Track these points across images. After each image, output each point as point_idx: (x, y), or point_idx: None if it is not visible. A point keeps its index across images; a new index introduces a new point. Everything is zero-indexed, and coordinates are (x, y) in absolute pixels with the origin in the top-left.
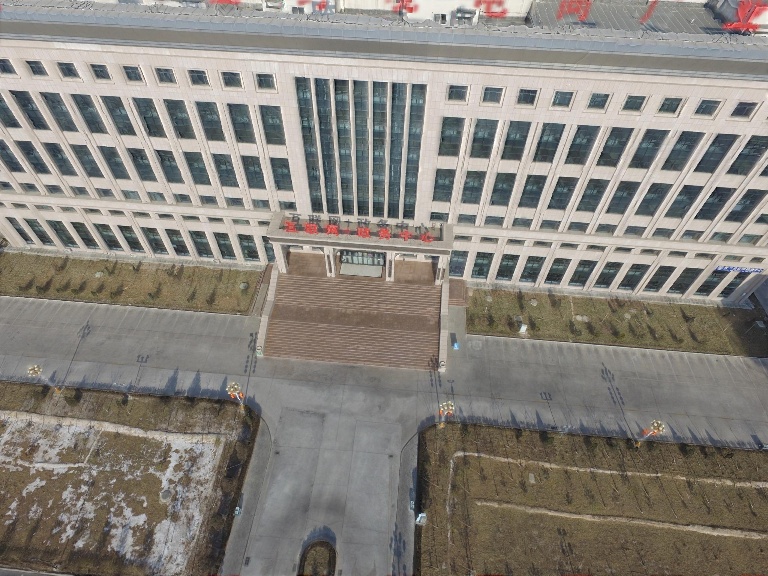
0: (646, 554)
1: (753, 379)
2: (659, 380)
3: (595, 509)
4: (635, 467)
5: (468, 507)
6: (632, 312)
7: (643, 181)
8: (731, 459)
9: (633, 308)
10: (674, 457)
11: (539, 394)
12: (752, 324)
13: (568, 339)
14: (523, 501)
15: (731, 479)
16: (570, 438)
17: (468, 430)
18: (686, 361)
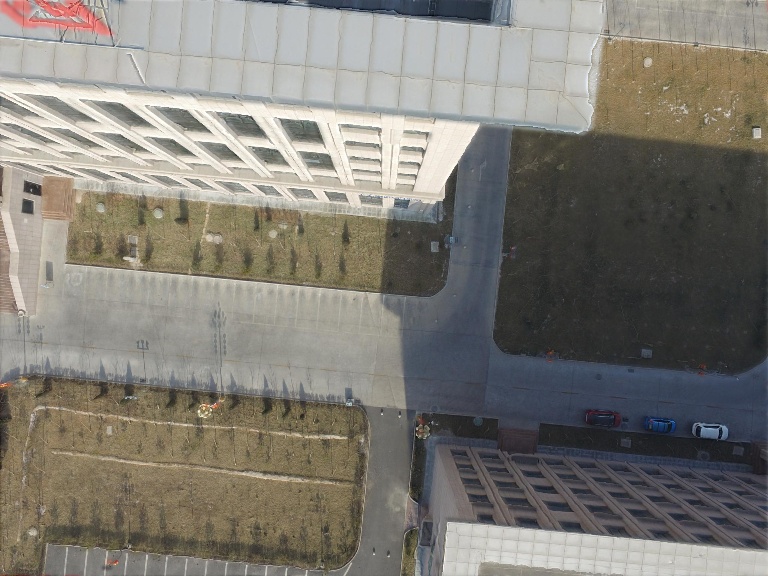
0: (197, 493)
1: (383, 324)
2: (275, 325)
3: (162, 458)
4: (212, 421)
5: (45, 456)
6: (281, 228)
7: (124, 136)
8: (312, 413)
9: (284, 222)
10: (255, 411)
11: (135, 343)
12: (424, 246)
13: (187, 270)
14: (97, 451)
15: (301, 433)
16: (156, 392)
17: (52, 384)
18: (317, 300)
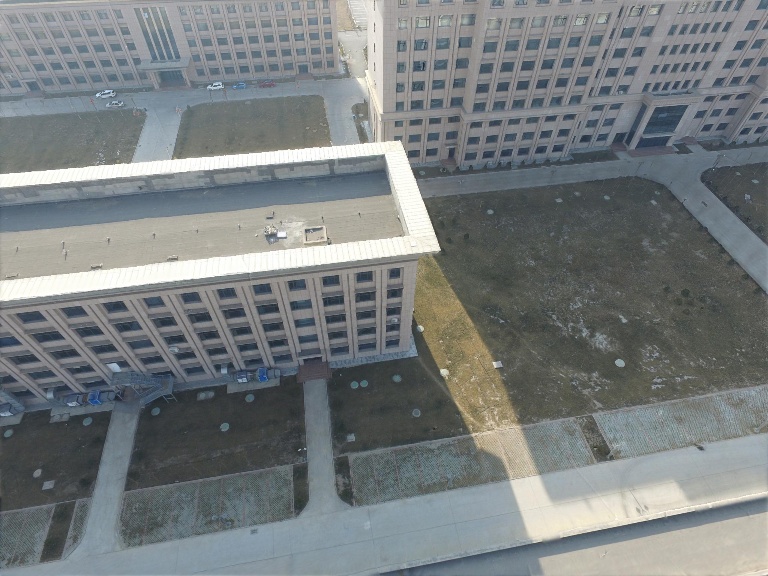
0: None
1: None
2: None
3: None
4: None
5: None
6: None
7: None
8: None
9: None
10: None
11: None
12: (366, 115)
13: None
14: None
15: None
16: None
17: None
18: None
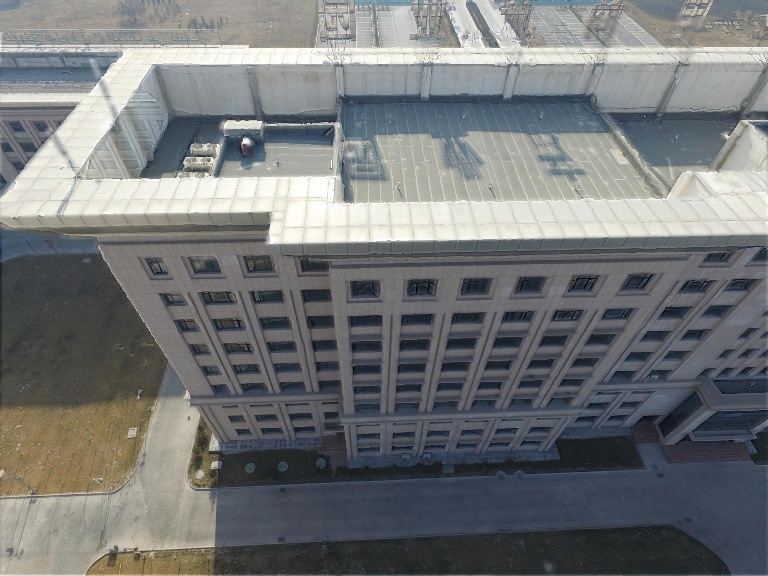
0: None
1: None
2: None
3: None
4: None
5: None
6: None
7: None
8: None
9: None
10: None
11: None
12: None
13: None
14: None
15: None
16: None
17: None
18: None
